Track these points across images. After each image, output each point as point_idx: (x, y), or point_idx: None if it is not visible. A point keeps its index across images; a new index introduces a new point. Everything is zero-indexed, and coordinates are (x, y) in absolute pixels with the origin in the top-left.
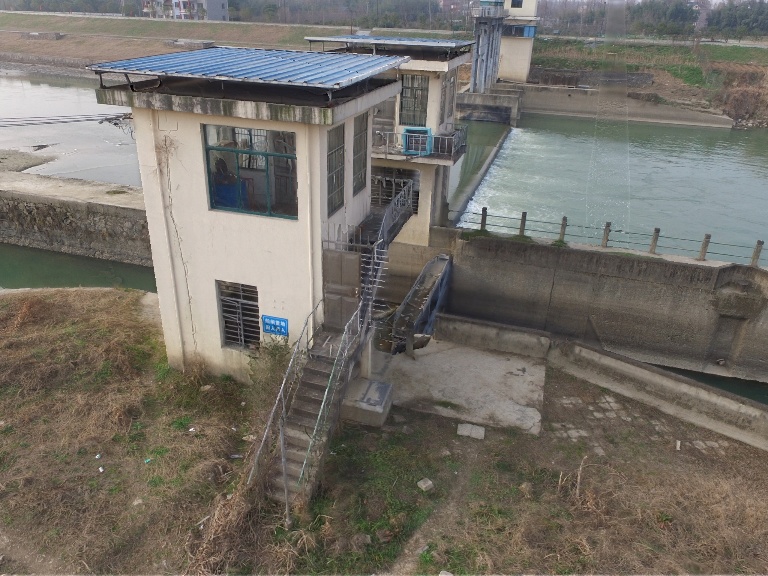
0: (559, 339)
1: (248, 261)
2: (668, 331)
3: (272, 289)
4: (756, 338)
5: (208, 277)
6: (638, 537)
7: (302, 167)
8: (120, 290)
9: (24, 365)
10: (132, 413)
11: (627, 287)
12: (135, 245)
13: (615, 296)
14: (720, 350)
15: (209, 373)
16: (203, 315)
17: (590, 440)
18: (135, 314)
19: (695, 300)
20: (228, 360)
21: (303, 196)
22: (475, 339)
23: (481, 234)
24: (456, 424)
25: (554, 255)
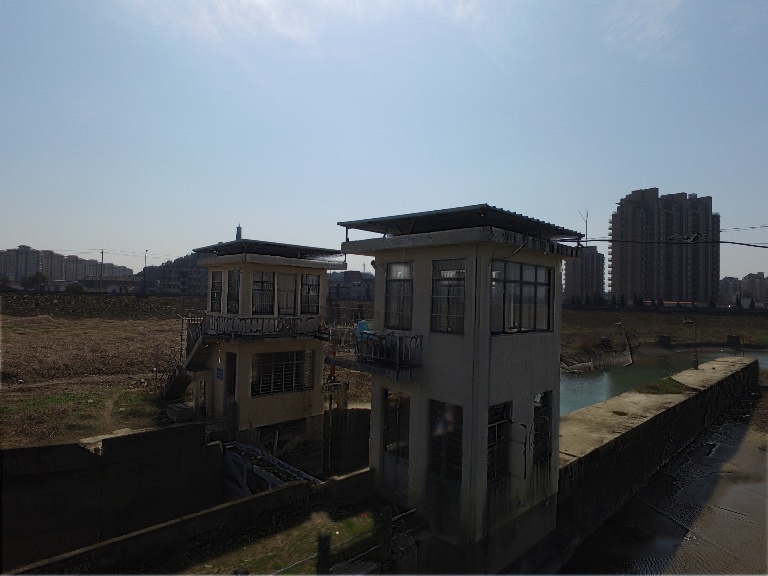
0: None
1: None
2: None
3: None
4: None
5: None
6: (6, 429)
7: None
8: None
9: None
10: None
11: None
12: None
13: None
14: None
15: None
16: None
17: None
18: None
19: None
20: None
21: None
22: None
23: (365, 542)
24: None
25: None
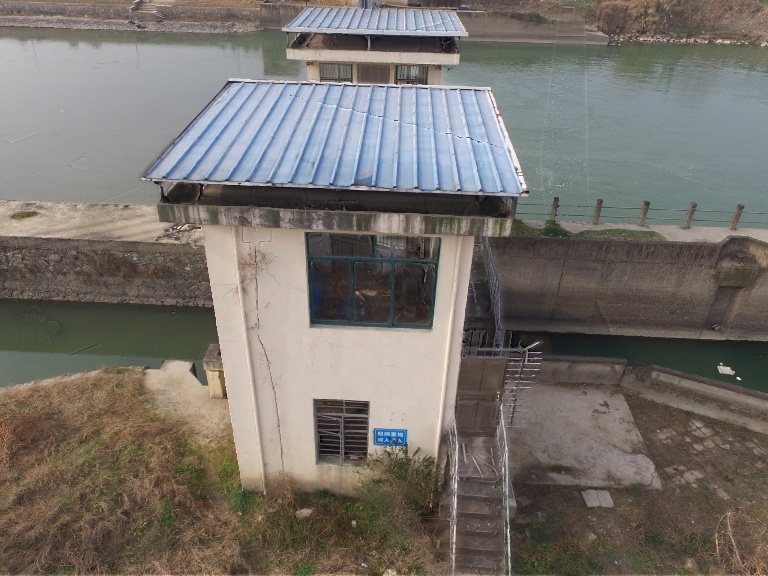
0: (566, 325)
1: (361, 377)
2: (671, 306)
3: (390, 402)
4: (750, 304)
5: (304, 397)
6: None
7: (446, 275)
8: (110, 373)
9: (59, 532)
10: (237, 575)
11: (635, 270)
12: (67, 279)
13: (623, 280)
14: (715, 317)
15: (298, 490)
16: (294, 435)
17: (708, 482)
18: (149, 408)
19: (698, 276)
20: (324, 475)
21: (443, 306)
22: (545, 374)
23: None
24: (579, 493)
25: (564, 247)
